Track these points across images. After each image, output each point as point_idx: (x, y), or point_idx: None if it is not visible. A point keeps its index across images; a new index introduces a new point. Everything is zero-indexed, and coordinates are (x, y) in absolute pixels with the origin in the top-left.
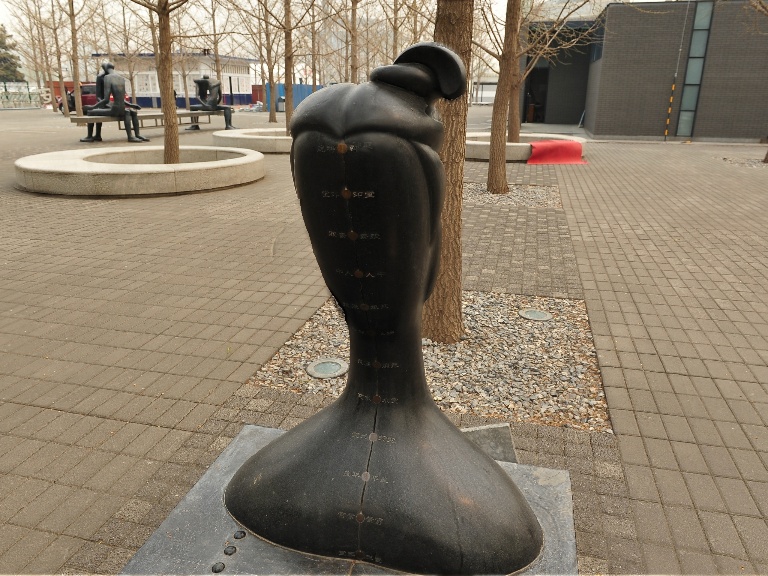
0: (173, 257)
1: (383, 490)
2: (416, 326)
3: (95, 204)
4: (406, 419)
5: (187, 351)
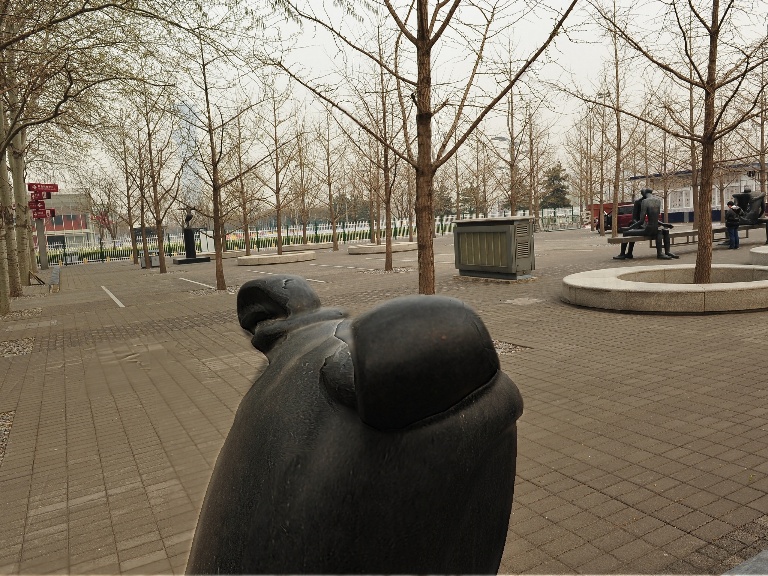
0: (697, 376)
1: None
2: None
3: (625, 318)
4: None
5: (706, 468)
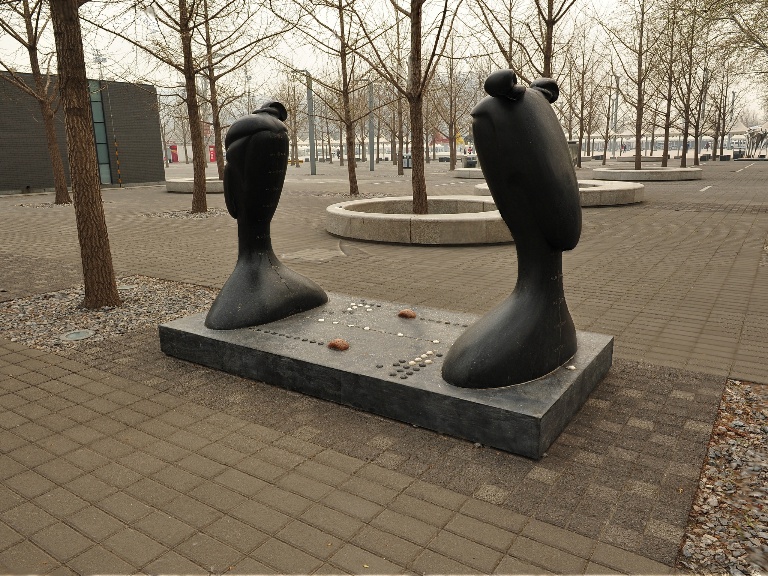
0: None
1: (291, 282)
2: None
3: None
4: None
5: None
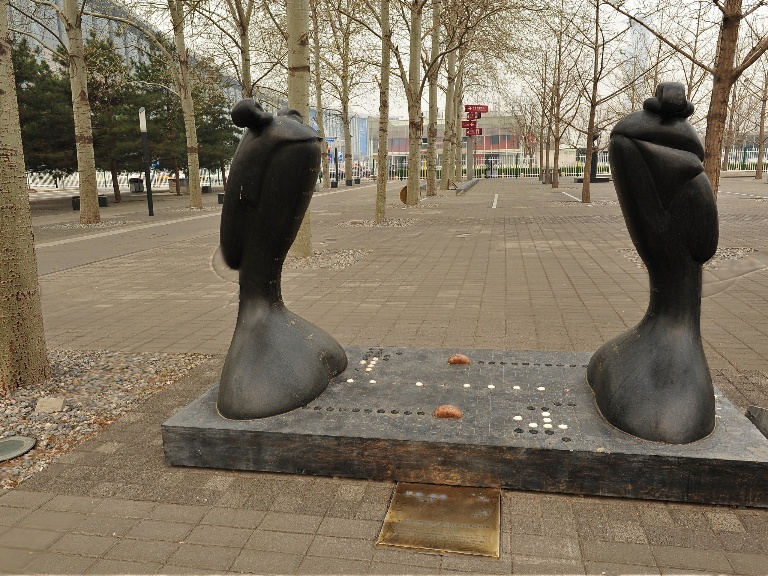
0: None
1: None
2: (674, 268)
3: None
4: (652, 328)
5: None
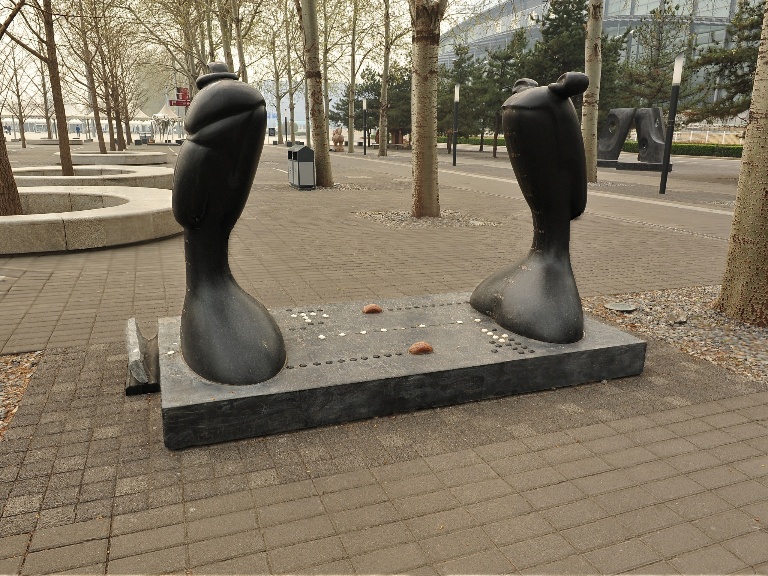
0: None
1: None
2: None
3: None
4: None
5: None
